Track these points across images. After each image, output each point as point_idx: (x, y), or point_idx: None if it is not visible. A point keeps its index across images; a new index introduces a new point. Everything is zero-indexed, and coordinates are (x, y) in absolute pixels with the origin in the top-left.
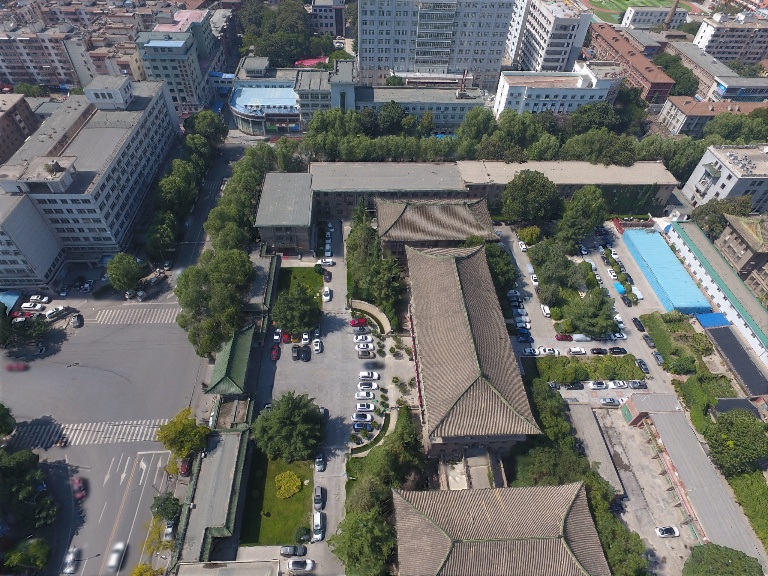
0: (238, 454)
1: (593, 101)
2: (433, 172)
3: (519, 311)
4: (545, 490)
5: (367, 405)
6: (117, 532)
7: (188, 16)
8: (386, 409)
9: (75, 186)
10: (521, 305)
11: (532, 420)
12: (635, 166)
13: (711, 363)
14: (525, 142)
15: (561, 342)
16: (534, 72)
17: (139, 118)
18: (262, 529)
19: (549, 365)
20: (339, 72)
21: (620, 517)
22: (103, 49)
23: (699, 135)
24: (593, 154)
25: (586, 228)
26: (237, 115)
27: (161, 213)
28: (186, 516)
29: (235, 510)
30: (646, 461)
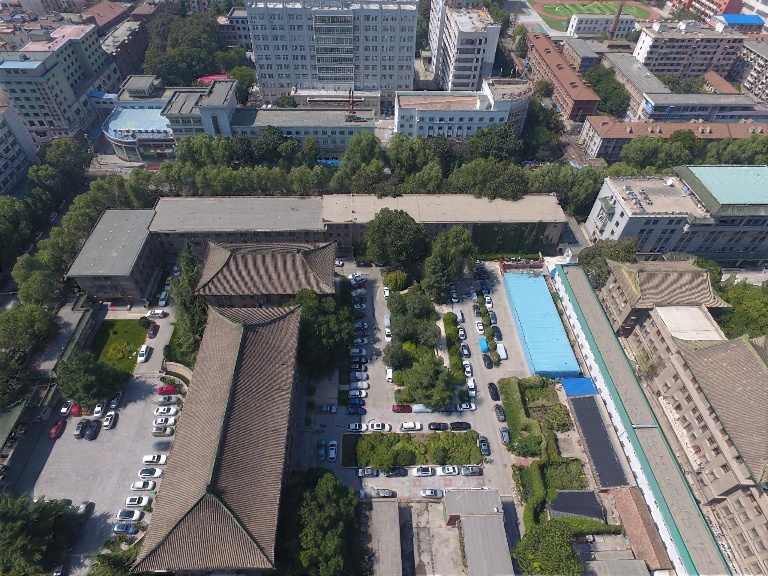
0: None
1: (493, 124)
2: (293, 208)
3: (357, 375)
4: None
5: (139, 499)
6: None
7: (69, 32)
8: None
9: None
10: (363, 367)
11: (269, 547)
12: (523, 200)
13: (567, 441)
14: (417, 169)
15: (397, 414)
16: (432, 92)
17: None
18: None
19: (373, 445)
20: (212, 94)
21: None
22: None
23: (619, 159)
24: (476, 187)
25: (449, 276)
26: (109, 140)
27: None
28: None
29: None
30: (454, 575)
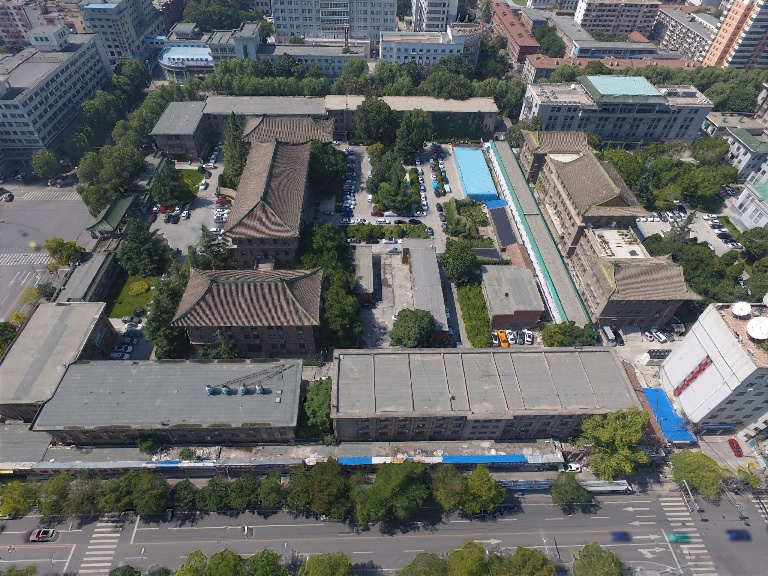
0: (102, 263)
1: (452, 54)
2: (304, 103)
3: (348, 197)
4: (296, 271)
5: None
6: (13, 309)
7: None
8: (224, 251)
9: (8, 96)
10: (352, 194)
11: (296, 230)
12: (469, 100)
13: (485, 231)
14: None
15: (374, 217)
16: (407, 32)
17: (69, 57)
18: (114, 310)
19: (358, 229)
20: (243, 30)
21: (371, 310)
22: (55, 13)
23: None
24: (436, 91)
25: (412, 140)
26: (163, 67)
27: (80, 125)
28: (57, 292)
29: (92, 292)
30: (405, 283)
